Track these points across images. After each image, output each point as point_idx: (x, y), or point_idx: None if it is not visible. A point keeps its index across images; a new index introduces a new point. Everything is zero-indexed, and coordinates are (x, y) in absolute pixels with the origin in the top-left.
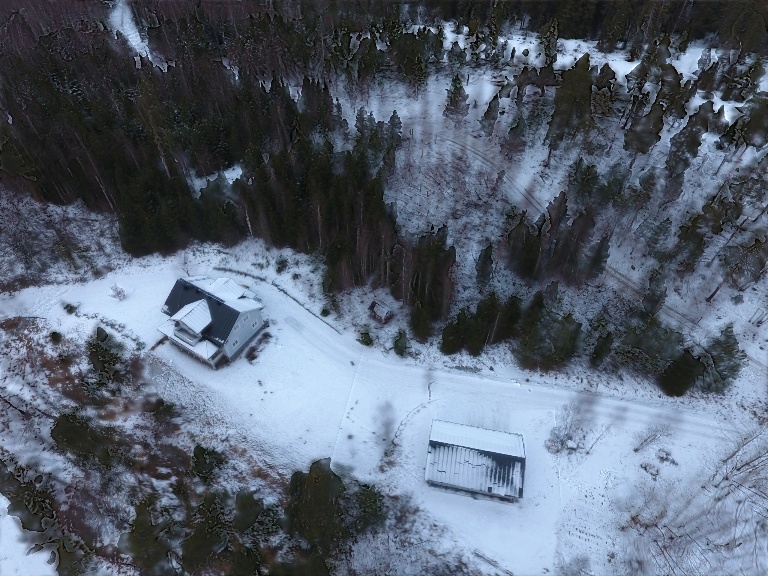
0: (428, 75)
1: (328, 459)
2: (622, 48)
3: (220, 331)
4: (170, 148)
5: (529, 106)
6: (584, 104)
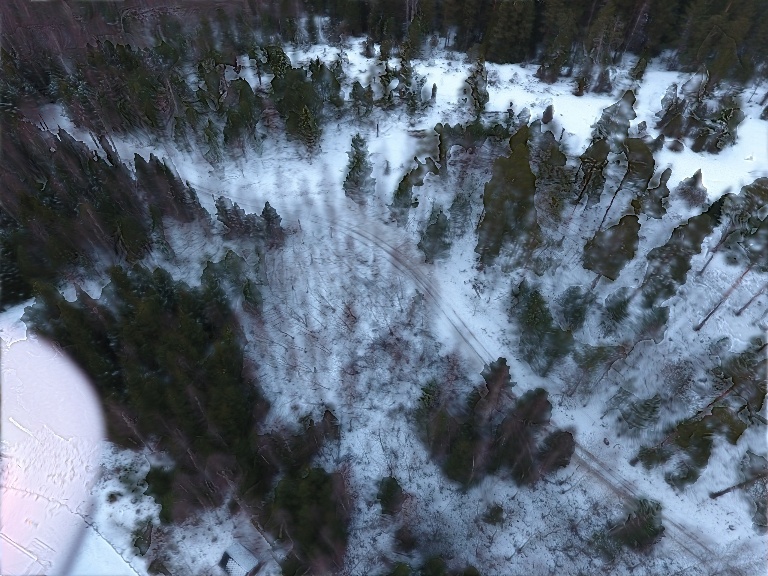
0: (320, 134)
1: None
2: (567, 74)
3: None
4: None
5: (456, 169)
6: (525, 209)
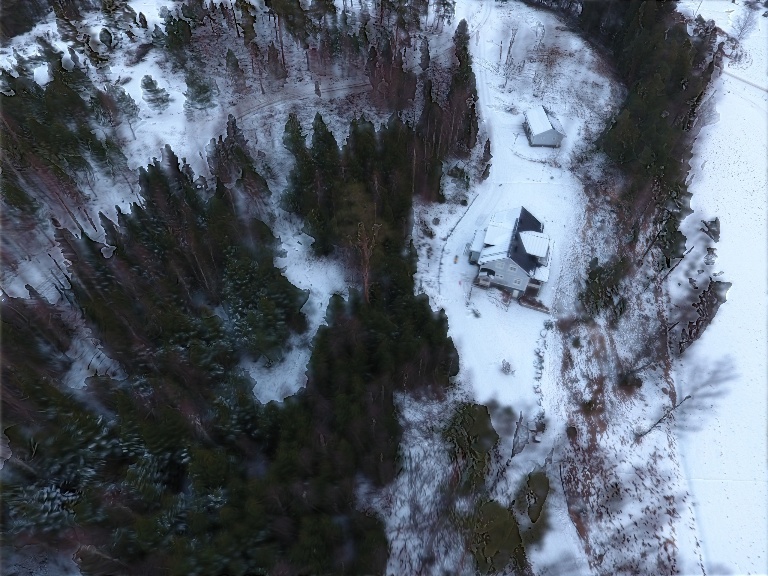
0: None
1: (616, 117)
2: None
3: (536, 225)
4: (273, 348)
5: (182, 71)
6: None
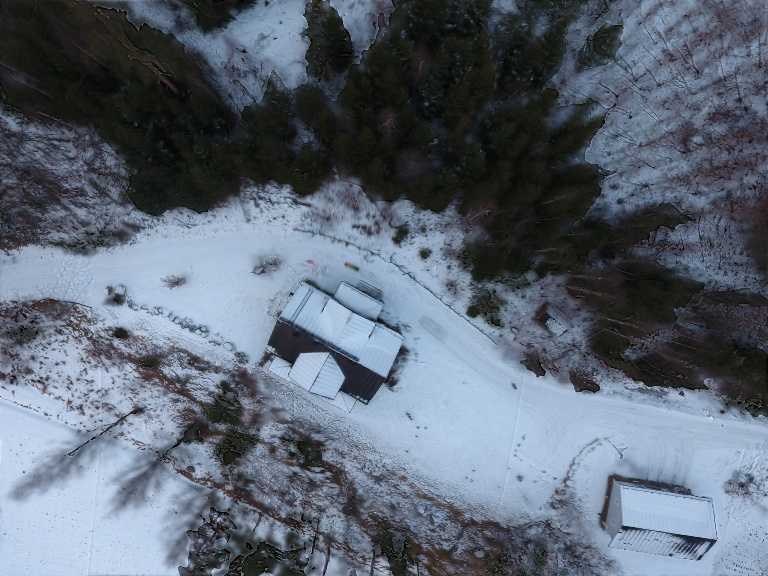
0: None
1: None
2: None
3: (360, 391)
4: None
5: None
6: None
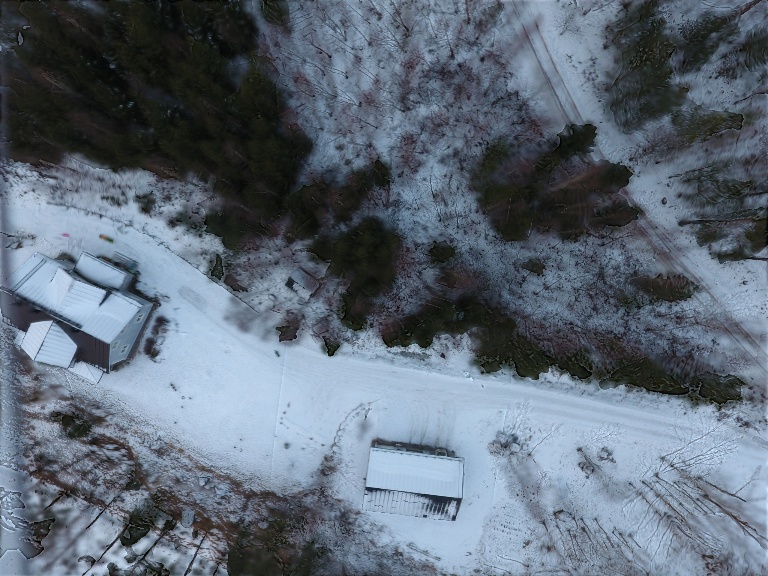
0: None
1: None
2: None
3: (95, 359)
4: None
5: None
6: None
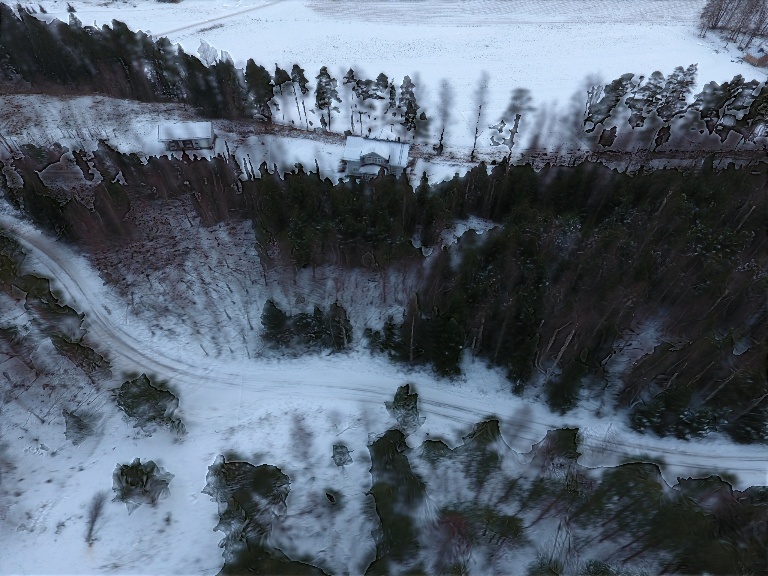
0: None
1: (249, 69)
2: None
3: None
4: None
5: None
6: None
